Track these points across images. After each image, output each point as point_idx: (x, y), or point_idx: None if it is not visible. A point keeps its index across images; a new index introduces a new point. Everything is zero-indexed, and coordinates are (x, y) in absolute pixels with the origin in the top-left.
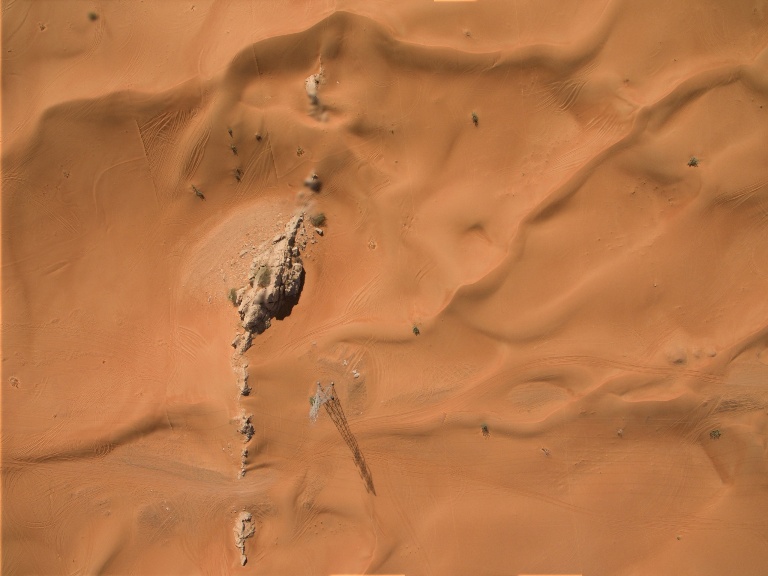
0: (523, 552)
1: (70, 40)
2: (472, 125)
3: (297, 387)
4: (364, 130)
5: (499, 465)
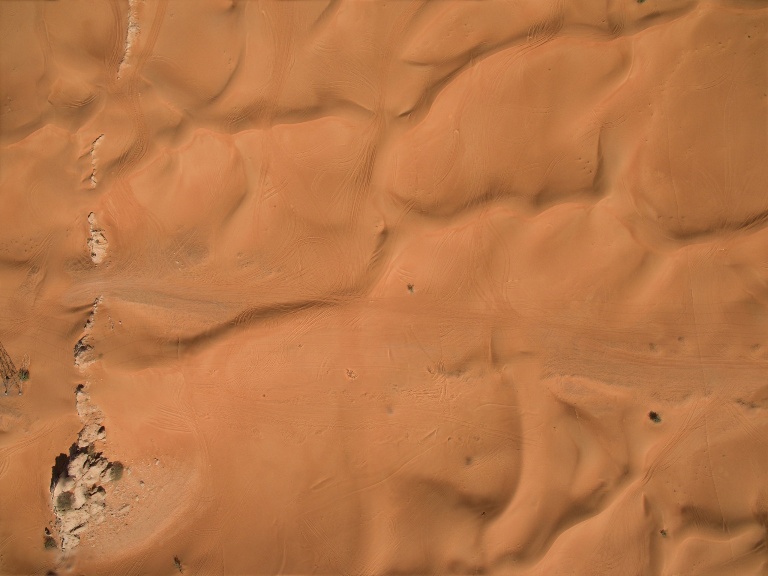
0: None
1: None
2: None
3: (40, 390)
4: None
5: None
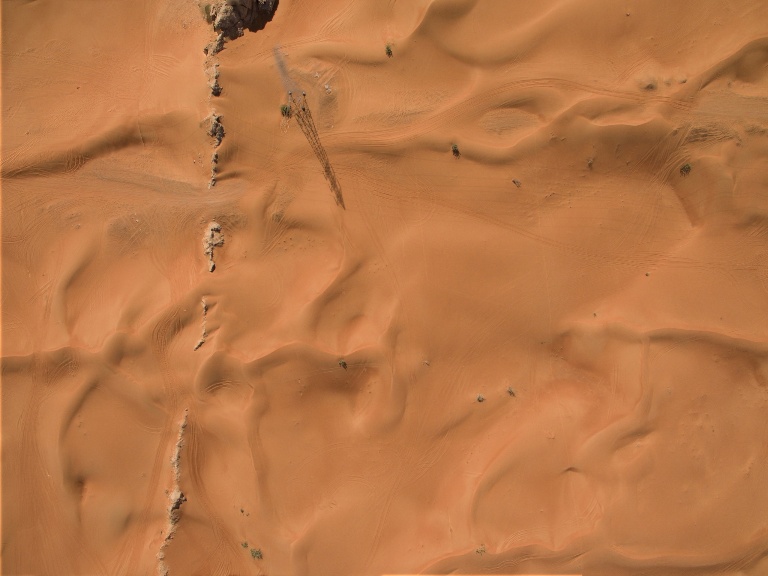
0: (491, 278)
1: None
2: None
3: (268, 95)
4: None
5: (469, 189)
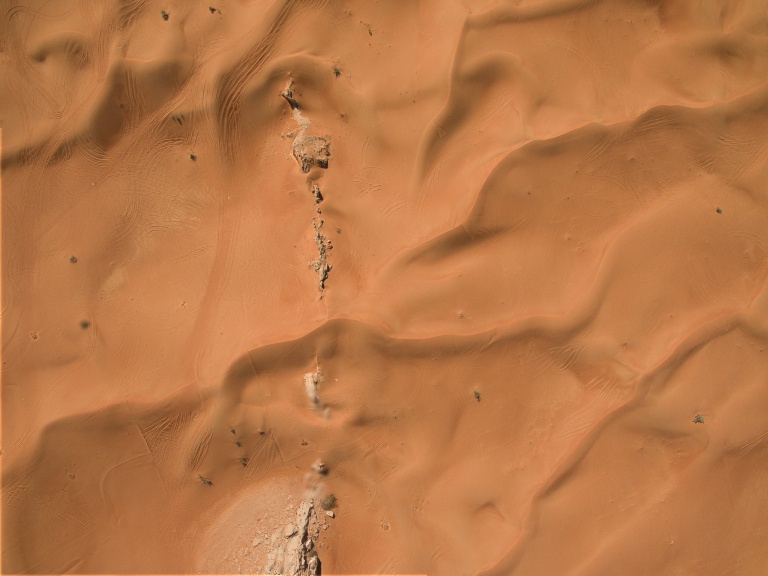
0: None
1: (64, 347)
2: (474, 401)
3: None
4: (367, 420)
5: None
